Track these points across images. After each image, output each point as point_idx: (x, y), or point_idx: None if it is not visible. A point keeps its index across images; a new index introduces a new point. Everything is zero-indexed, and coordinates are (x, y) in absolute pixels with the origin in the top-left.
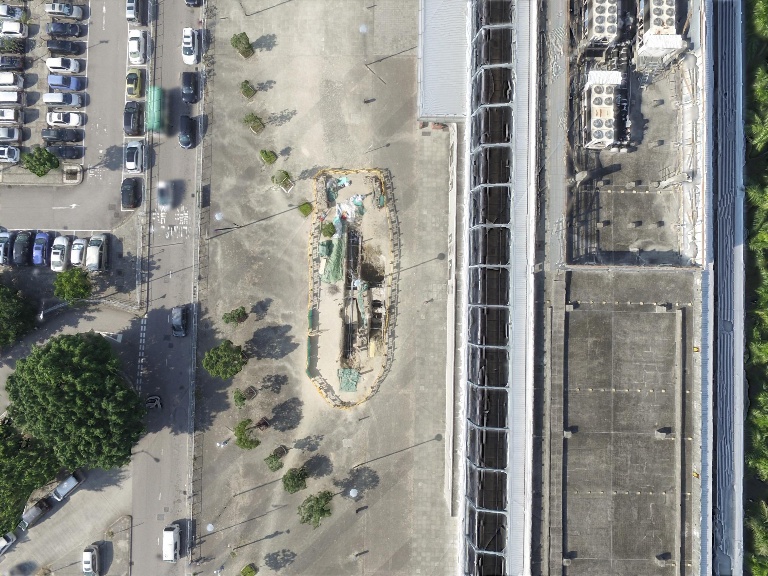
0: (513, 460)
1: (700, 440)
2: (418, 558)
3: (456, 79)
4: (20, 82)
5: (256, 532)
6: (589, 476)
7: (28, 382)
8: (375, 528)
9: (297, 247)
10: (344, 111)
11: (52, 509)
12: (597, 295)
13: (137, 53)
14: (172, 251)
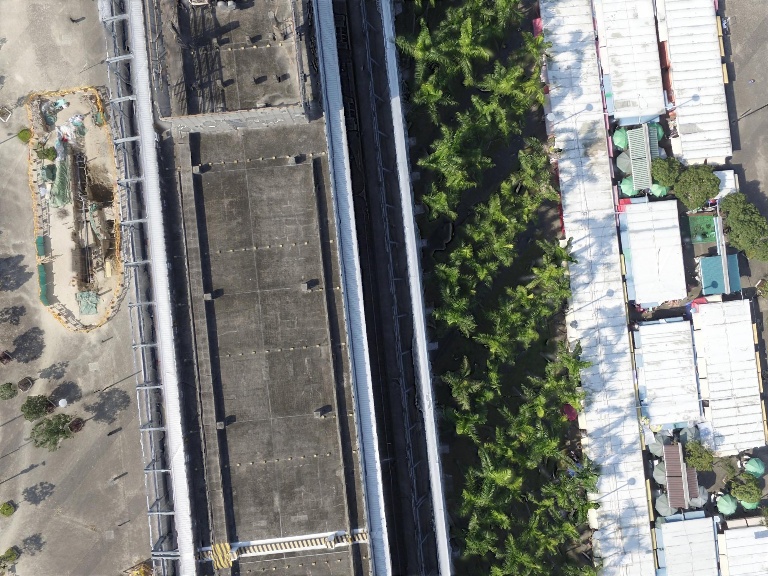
0: (161, 331)
1: (341, 286)
2: None
3: None
4: None
5: (11, 468)
6: (240, 338)
7: None
8: (131, 449)
9: (21, 175)
10: (55, 33)
11: None
12: (228, 155)
13: None
14: None
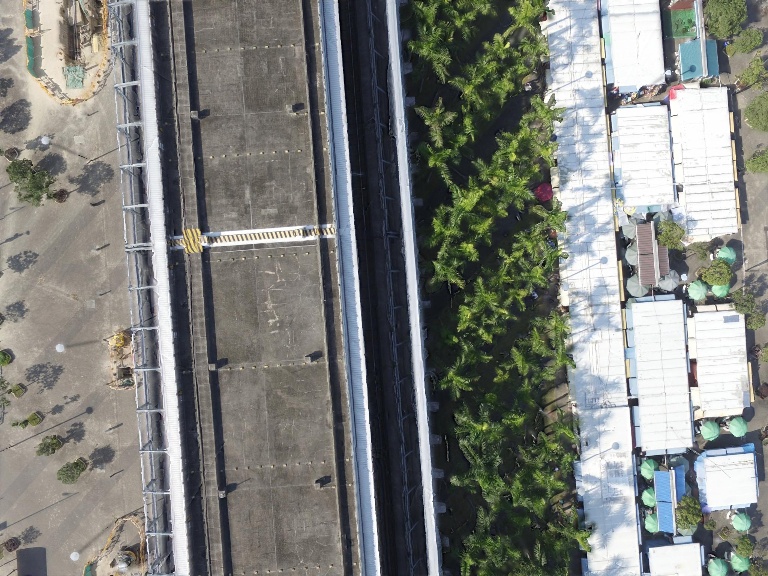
0: (139, 26)
1: None
2: None
3: None
4: None
5: None
6: (216, 35)
7: None
8: (114, 221)
9: None
10: None
11: None
12: None
13: None
14: None
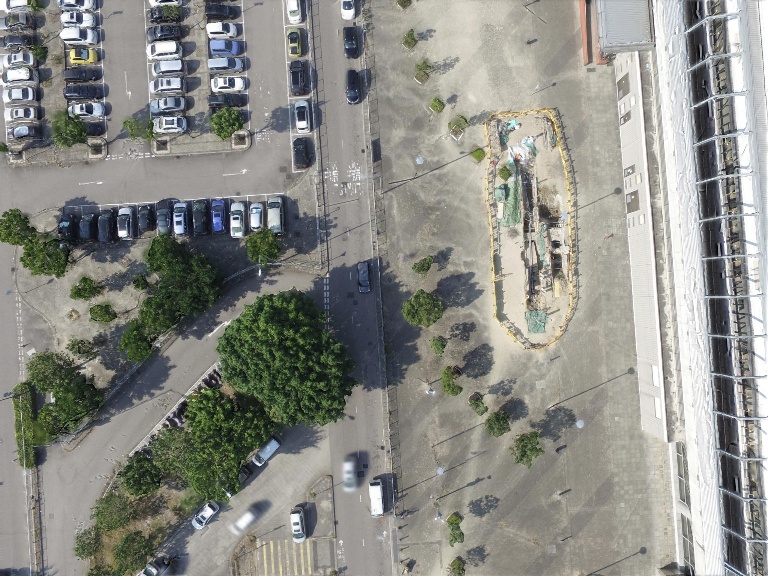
0: None
1: None
2: (621, 492)
3: (635, 7)
4: (180, 51)
5: (457, 480)
6: None
7: (250, 340)
8: (575, 466)
9: (473, 194)
10: (507, 54)
11: (251, 476)
12: None
13: (297, 11)
14: (347, 208)
